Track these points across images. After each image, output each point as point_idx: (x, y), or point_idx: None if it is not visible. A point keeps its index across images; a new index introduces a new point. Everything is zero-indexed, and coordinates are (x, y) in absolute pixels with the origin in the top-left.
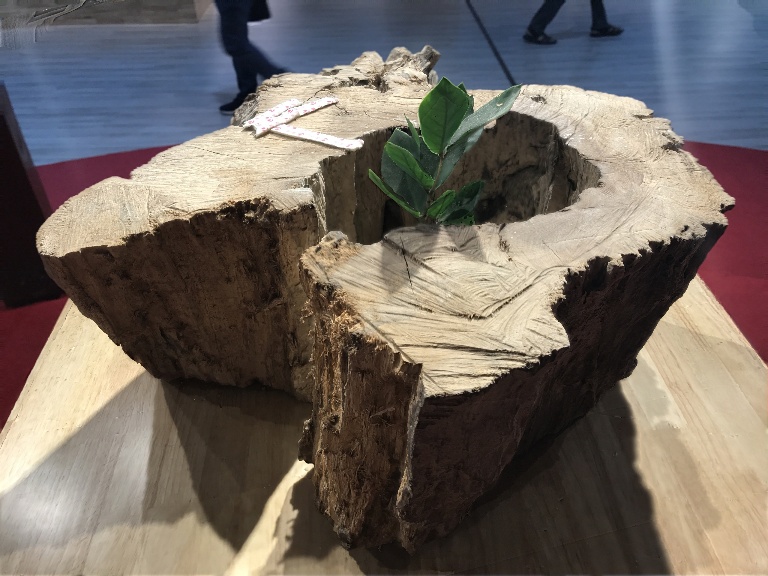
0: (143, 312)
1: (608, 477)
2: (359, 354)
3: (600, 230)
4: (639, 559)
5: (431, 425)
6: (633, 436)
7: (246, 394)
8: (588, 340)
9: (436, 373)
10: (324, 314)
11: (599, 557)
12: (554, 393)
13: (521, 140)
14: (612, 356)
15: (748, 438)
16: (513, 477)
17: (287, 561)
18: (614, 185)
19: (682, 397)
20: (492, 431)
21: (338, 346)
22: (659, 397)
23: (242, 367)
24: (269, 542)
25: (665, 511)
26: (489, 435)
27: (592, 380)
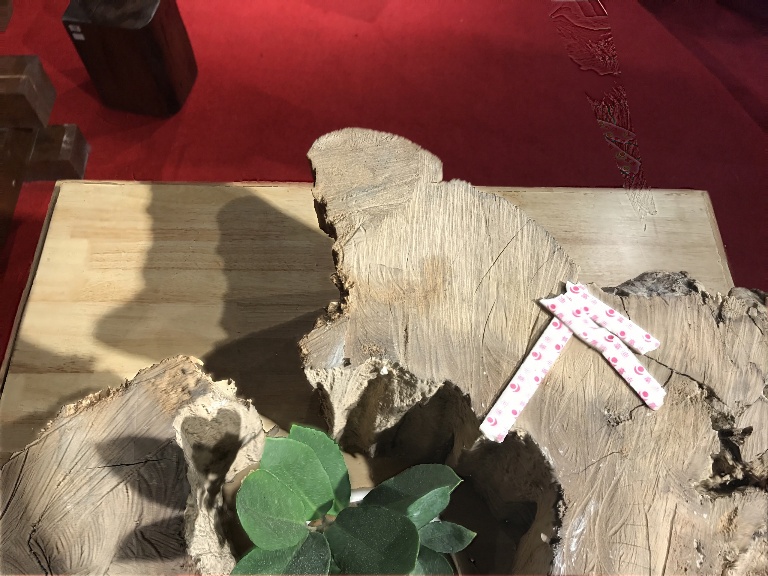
0: None
1: None
2: None
3: None
4: None
5: None
6: None
7: None
8: None
9: None
10: None
11: None
12: None
13: None
14: None
15: None
16: None
17: None
18: None
19: None
20: None
21: None
22: None
23: None
24: None
25: None
26: None
27: None
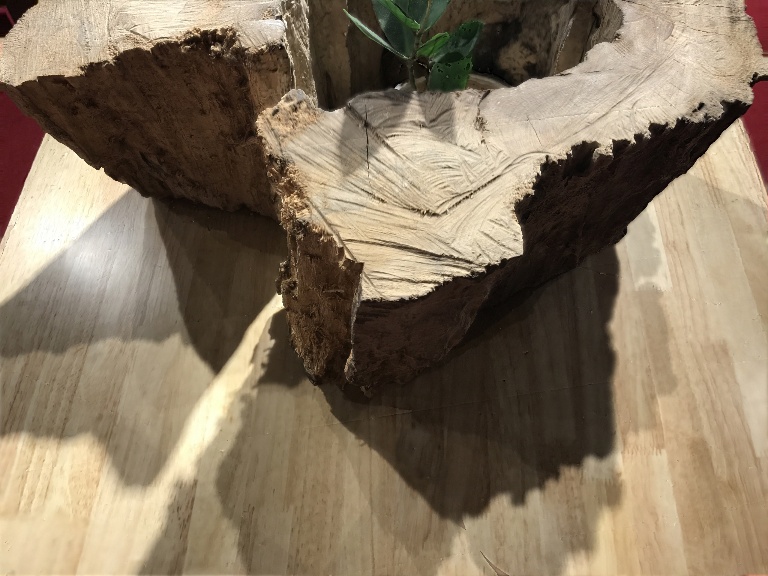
0: (119, 138)
1: (577, 335)
2: (306, 240)
3: (598, 105)
4: (587, 415)
5: (369, 321)
6: (613, 295)
7: (234, 218)
8: (573, 212)
9: (376, 275)
10: (277, 189)
11: (549, 410)
12: (536, 253)
13: None
14: (599, 226)
15: (730, 308)
16: (484, 327)
17: (261, 386)
18: (633, 40)
19: (676, 258)
20: (436, 324)
21: (287, 228)
22: (652, 256)
23: (228, 194)
24: (246, 368)
25: (624, 373)
26: (433, 327)
27: (575, 246)
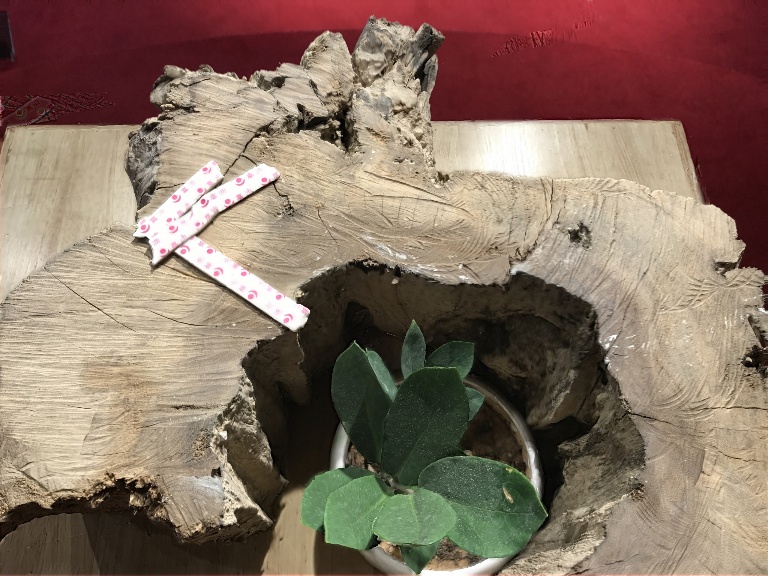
0: None
1: None
2: None
3: None
4: None
5: None
6: None
7: None
8: None
9: None
10: None
11: None
12: None
13: (542, 304)
14: None
15: None
16: None
17: None
18: (659, 493)
19: None
20: None
21: None
22: None
23: None
24: None
25: None
26: None
27: None
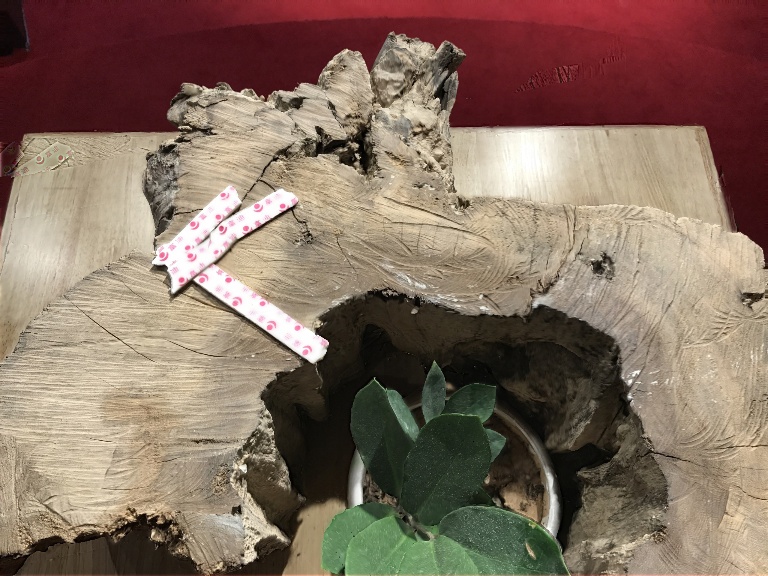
0: None
1: None
2: None
3: None
4: None
5: None
6: None
7: None
8: None
9: None
10: None
11: None
12: None
13: (564, 335)
14: None
15: None
16: None
17: None
18: (682, 536)
19: None
20: None
21: None
22: None
23: None
24: None
25: None
26: None
27: None
